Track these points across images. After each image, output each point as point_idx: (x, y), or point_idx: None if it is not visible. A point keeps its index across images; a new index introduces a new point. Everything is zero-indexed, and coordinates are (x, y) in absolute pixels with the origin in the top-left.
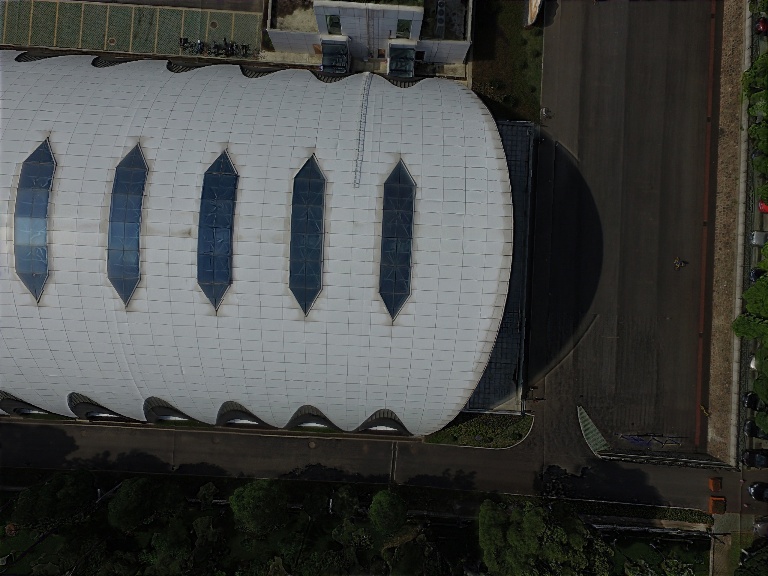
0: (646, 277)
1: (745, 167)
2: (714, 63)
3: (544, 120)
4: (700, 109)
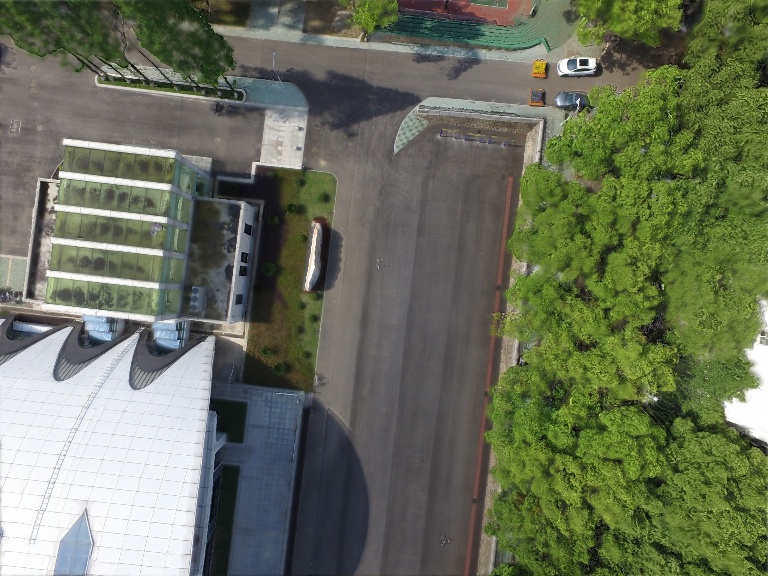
0: (410, 552)
1: None
2: (496, 336)
3: (317, 387)
4: (478, 383)
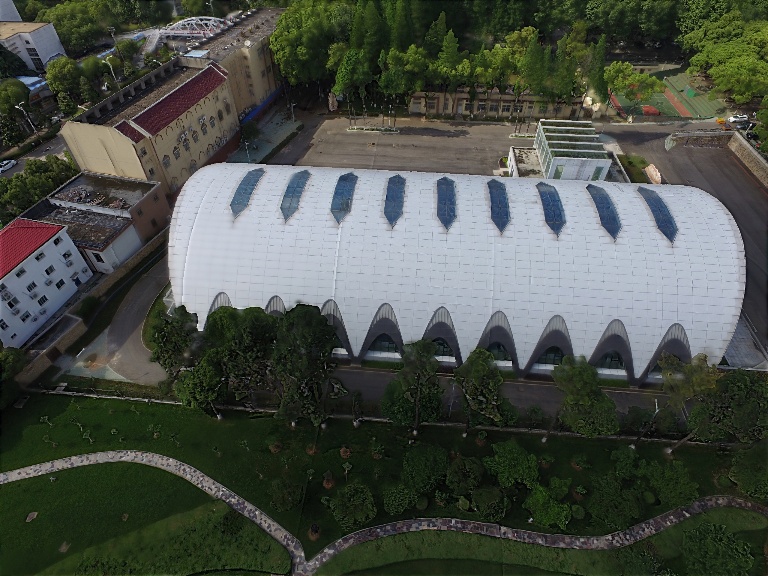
0: None
1: None
2: None
3: None
4: None
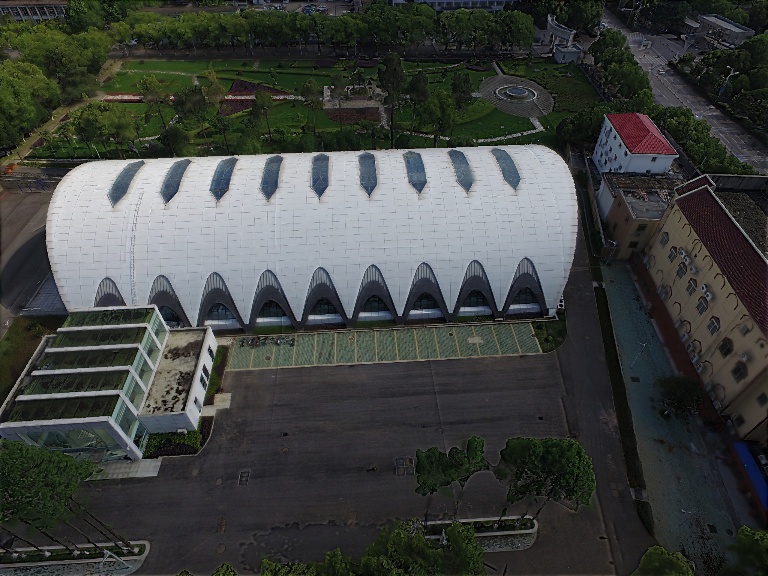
0: None
1: None
2: None
3: None
4: None
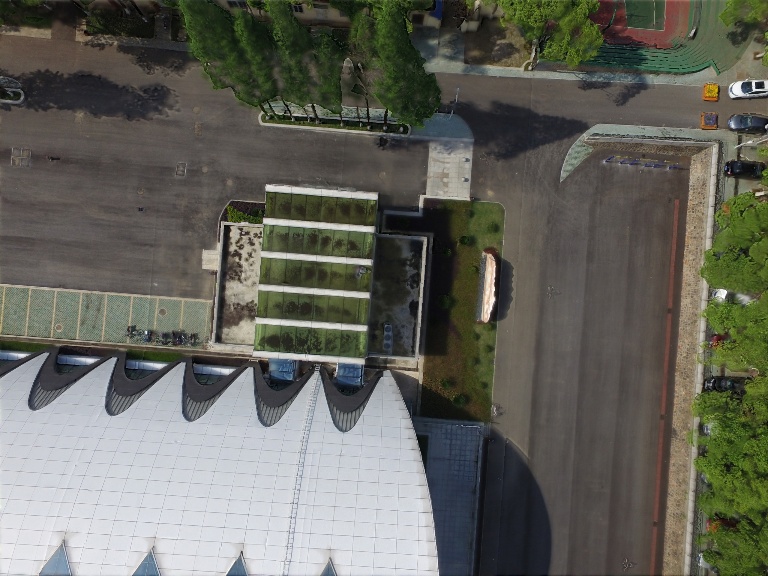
0: None
1: (694, 486)
2: (669, 359)
3: (495, 417)
4: (654, 407)
